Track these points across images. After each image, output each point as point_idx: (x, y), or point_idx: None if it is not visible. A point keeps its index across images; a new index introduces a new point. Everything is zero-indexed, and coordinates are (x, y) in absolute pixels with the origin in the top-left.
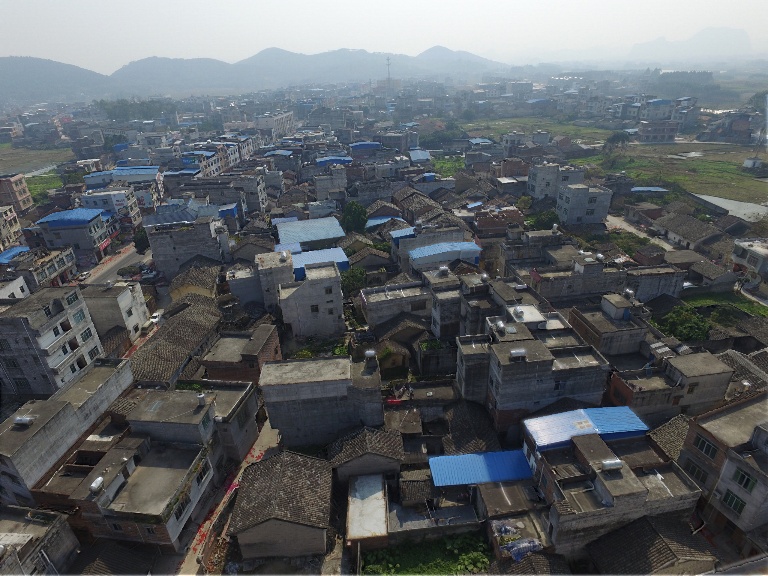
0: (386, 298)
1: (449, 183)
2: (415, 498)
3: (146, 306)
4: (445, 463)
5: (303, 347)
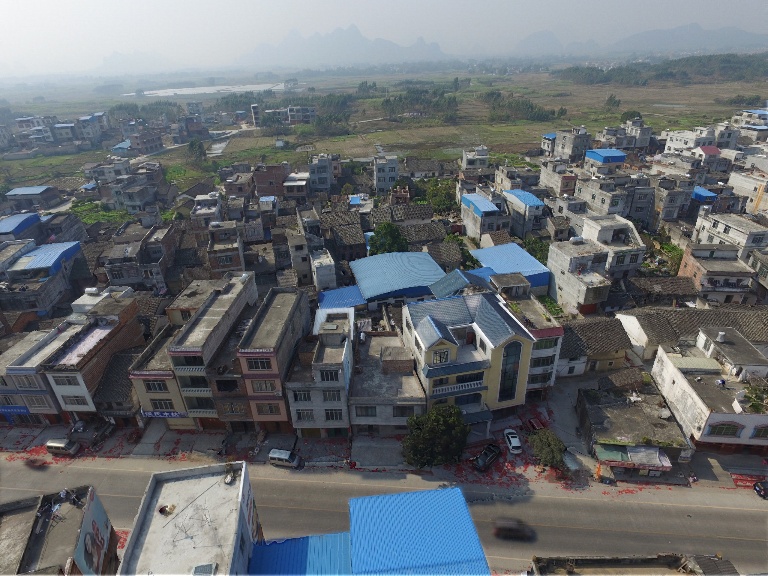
0: None
1: (277, 202)
2: None
3: None
4: None
5: None
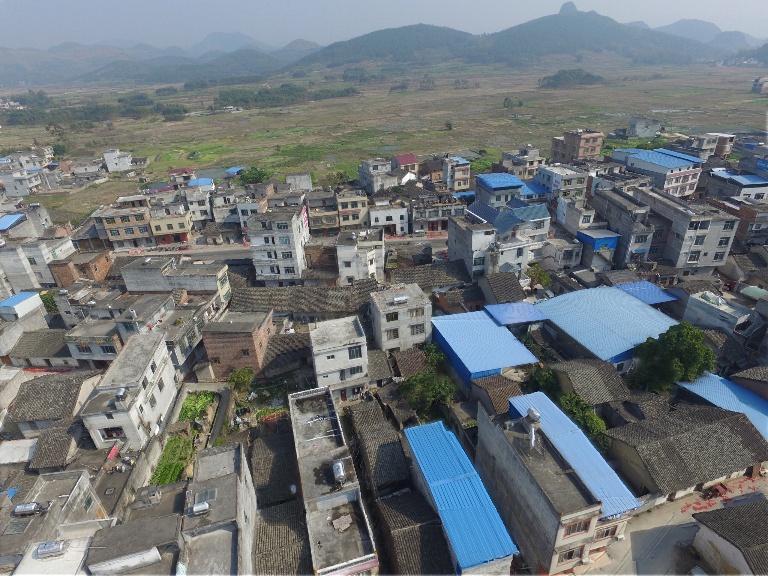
0: (310, 418)
1: None
2: (2, 487)
3: (384, 271)
4: None
5: (301, 384)
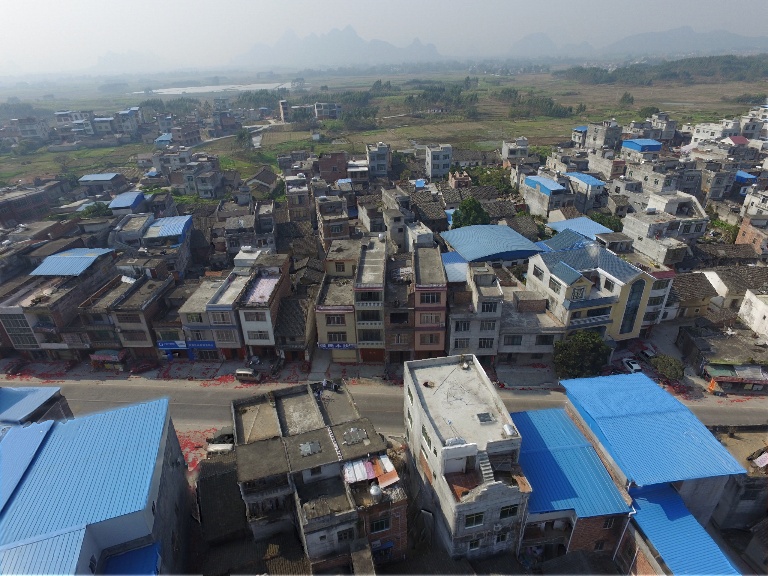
0: None
1: None
2: None
3: None
4: None
5: None
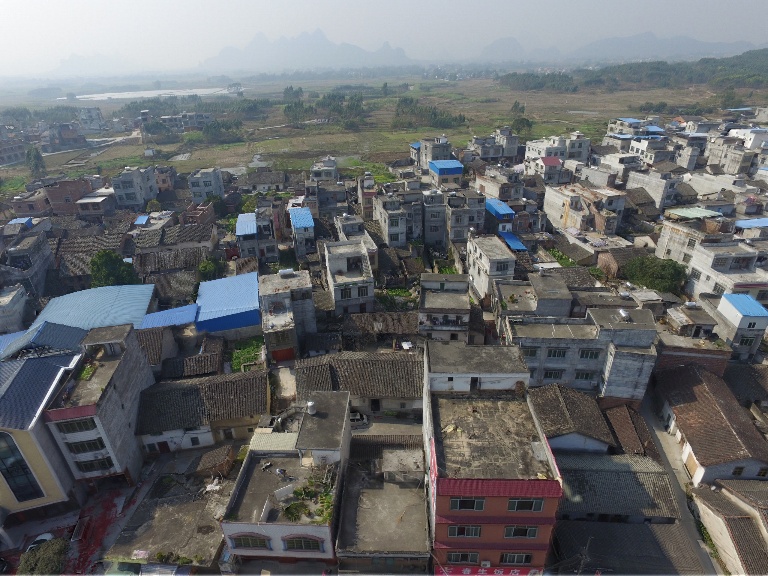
0: None
1: (46, 223)
2: None
3: None
4: (514, 246)
5: None
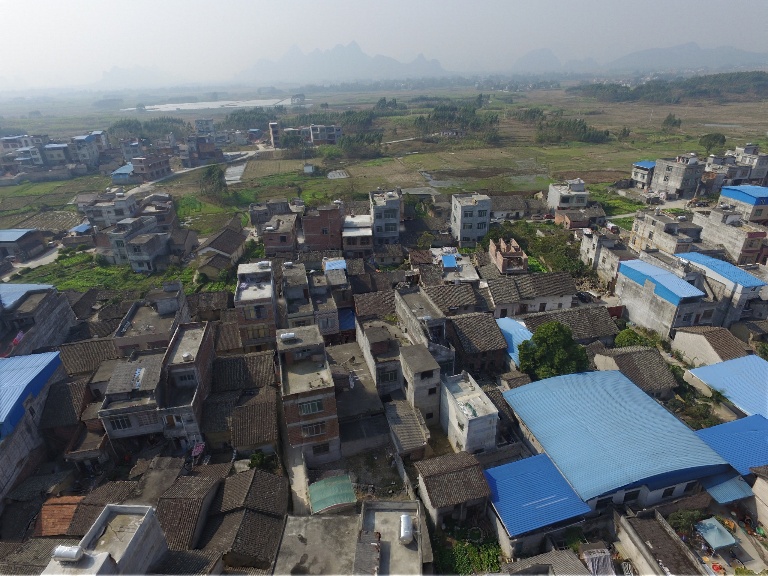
0: None
1: None
2: None
3: None
4: None
5: None
